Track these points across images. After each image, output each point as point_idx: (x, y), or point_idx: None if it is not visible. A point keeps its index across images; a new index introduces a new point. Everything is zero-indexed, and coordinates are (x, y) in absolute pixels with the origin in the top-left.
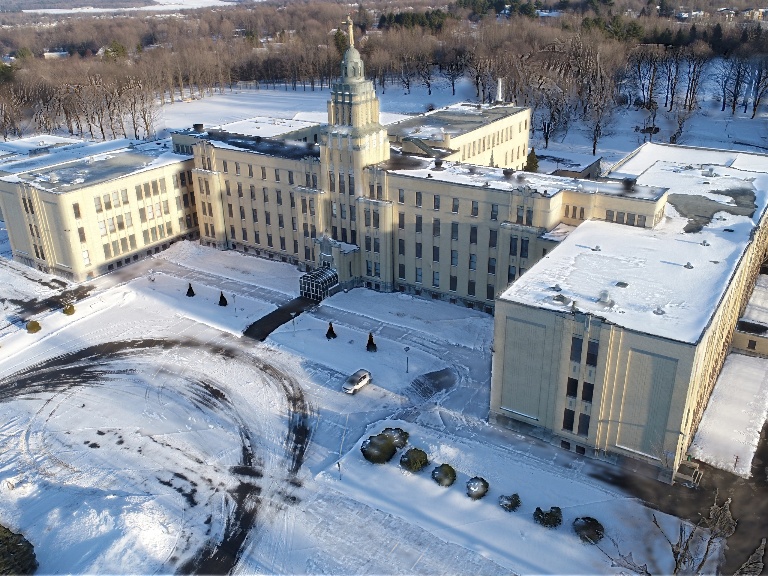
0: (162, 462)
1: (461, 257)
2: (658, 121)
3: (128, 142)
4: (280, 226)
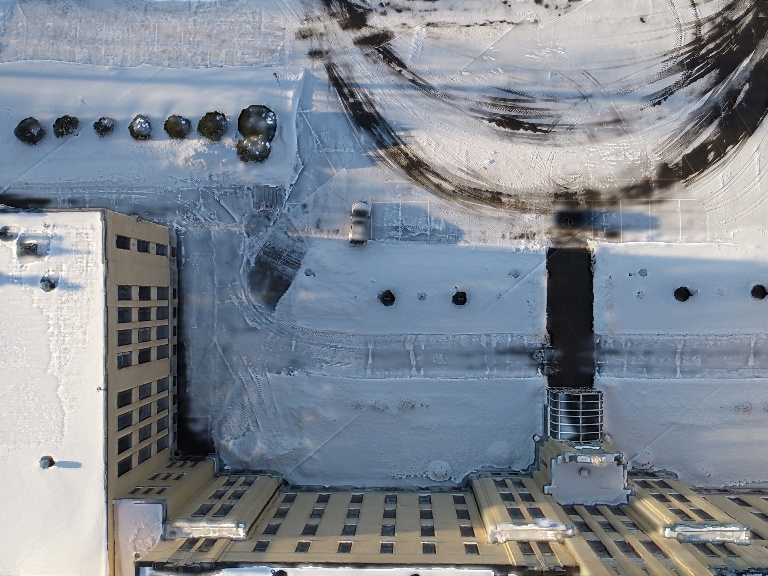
0: (467, 2)
1: (340, 513)
2: None
3: None
4: (764, 514)
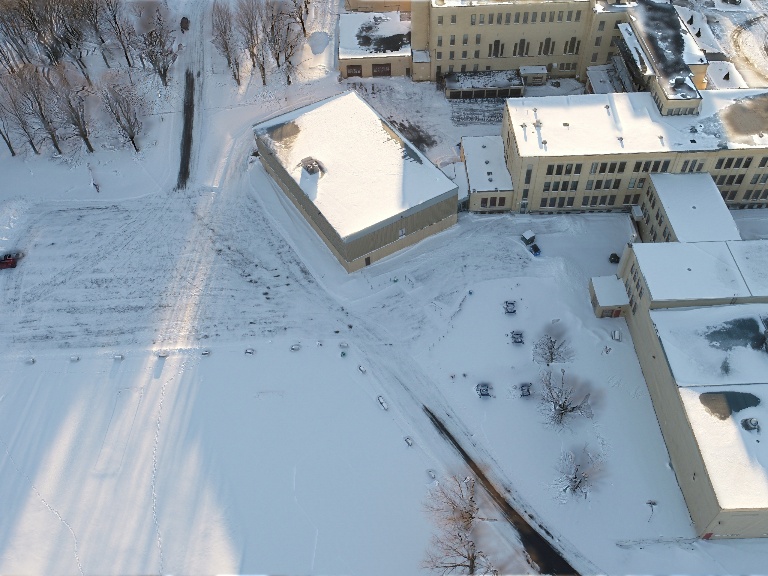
0: None
1: None
2: (164, 18)
3: (657, 276)
4: None
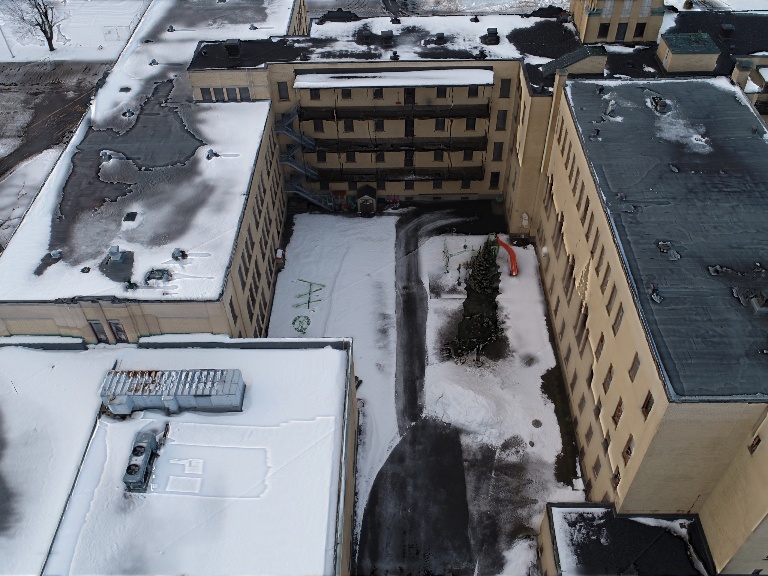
0: None
1: None
2: None
3: None
4: None
